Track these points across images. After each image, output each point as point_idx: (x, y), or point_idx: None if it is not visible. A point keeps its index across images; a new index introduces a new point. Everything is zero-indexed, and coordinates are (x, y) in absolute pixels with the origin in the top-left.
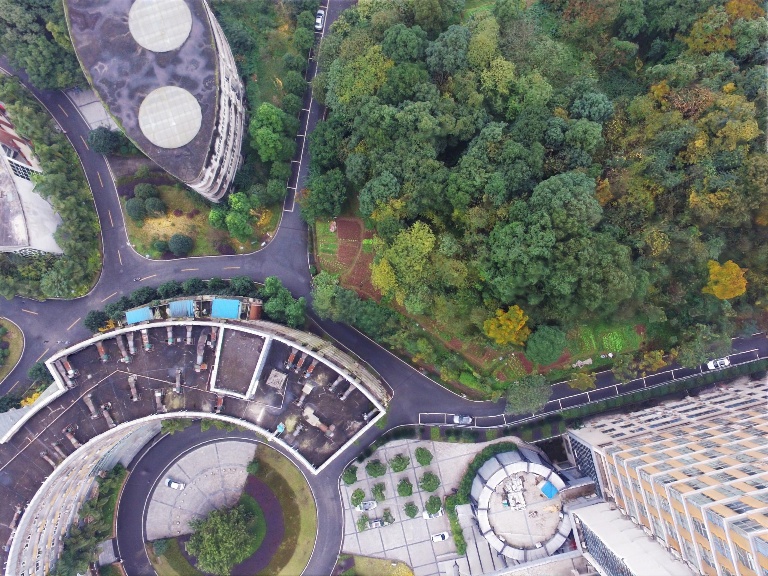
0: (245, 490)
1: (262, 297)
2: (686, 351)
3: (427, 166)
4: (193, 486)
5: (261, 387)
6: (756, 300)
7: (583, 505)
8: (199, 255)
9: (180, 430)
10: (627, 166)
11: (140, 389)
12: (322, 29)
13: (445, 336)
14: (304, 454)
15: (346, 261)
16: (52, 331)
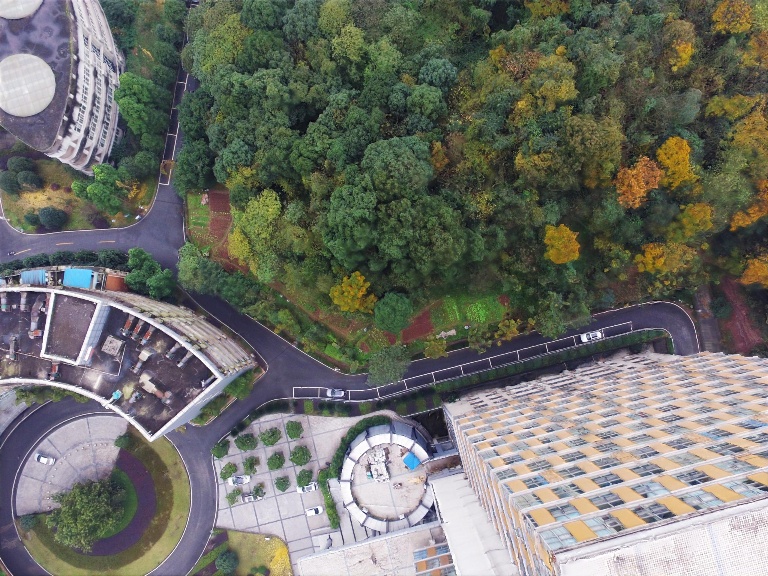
0: (116, 465)
1: (130, 270)
2: (545, 321)
3: (279, 134)
4: (64, 461)
5: (98, 354)
6: None
7: (443, 476)
8: (74, 229)
9: (39, 402)
10: (464, 130)
11: None
12: None
13: (309, 307)
14: (141, 421)
15: (218, 234)
16: None
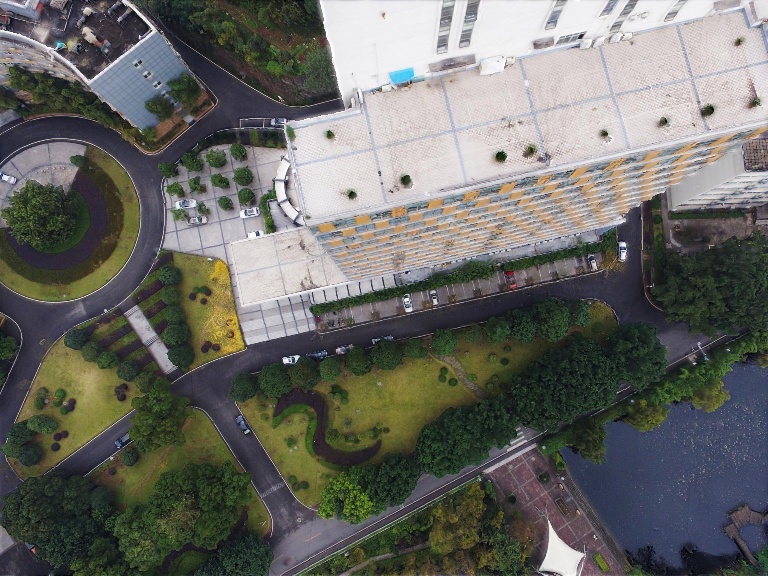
0: (72, 186)
1: None
2: None
3: None
4: (24, 182)
5: (47, 13)
6: None
7: None
8: None
9: (1, 104)
10: None
11: None
12: None
13: (252, 24)
14: (82, 71)
15: None
16: None
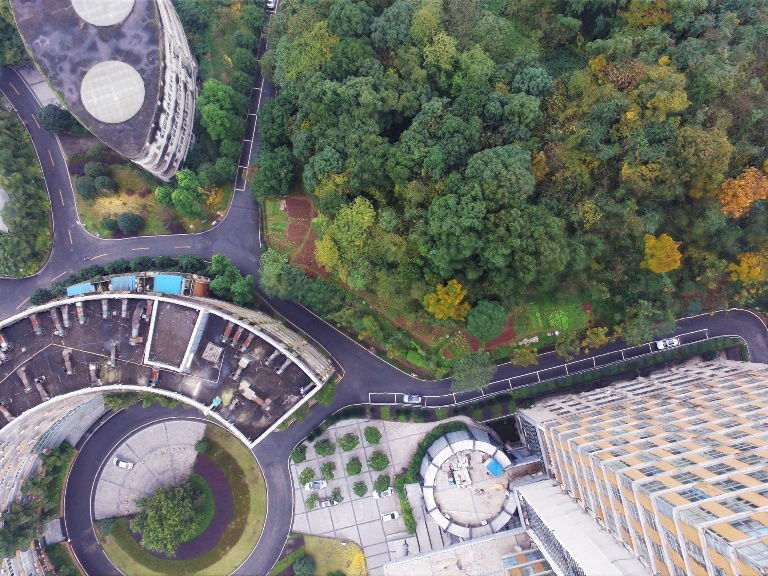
0: (194, 469)
1: (210, 275)
2: (630, 328)
3: (370, 141)
4: (142, 465)
5: (197, 361)
6: None
7: (527, 482)
8: (150, 234)
9: (125, 407)
10: (564, 140)
11: (75, 362)
12: (274, 7)
13: (392, 314)
14: (240, 428)
15: (296, 240)
16: (1, 310)
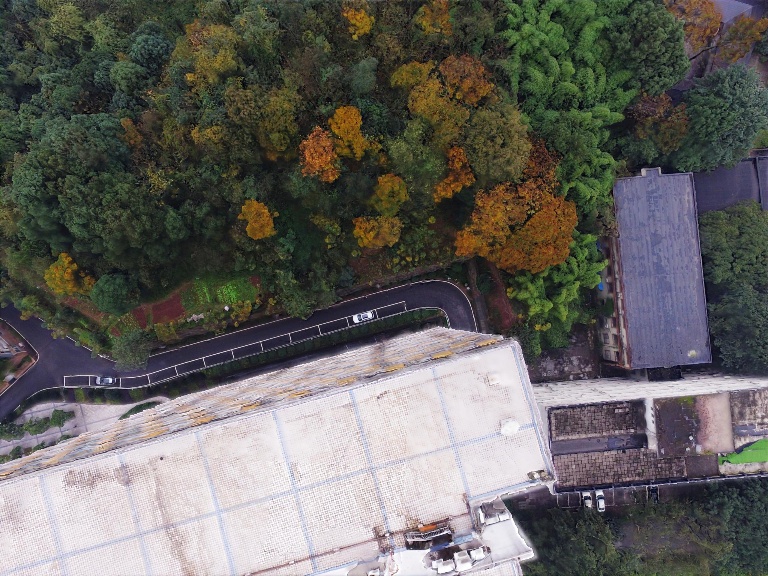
0: None
1: None
2: (289, 301)
3: (2, 117)
4: None
5: None
6: None
7: None
8: None
9: None
10: None
11: None
12: None
13: None
14: None
15: None
16: None
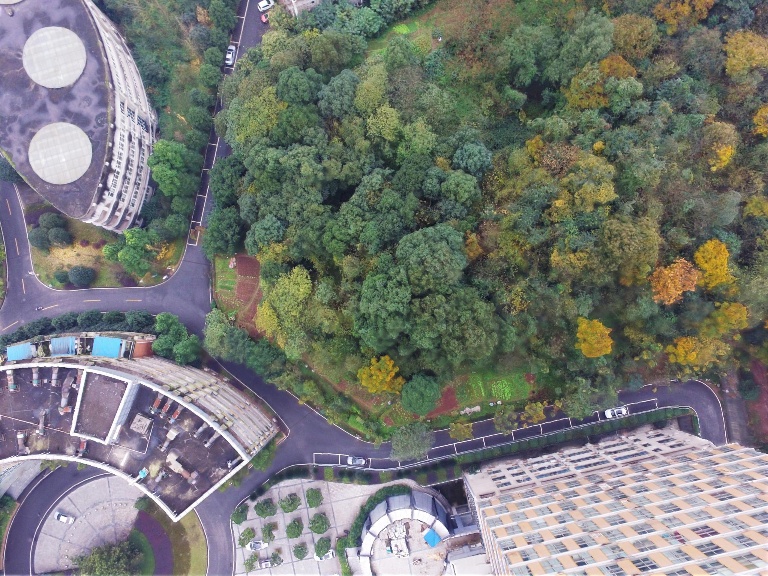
0: (135, 526)
1: (157, 332)
2: (572, 402)
3: (311, 210)
4: (83, 520)
5: (126, 431)
6: (639, 354)
7: (464, 555)
8: (101, 286)
9: None
10: (498, 220)
11: (4, 430)
12: (233, 64)
13: None
14: (167, 500)
15: (244, 298)
16: None
